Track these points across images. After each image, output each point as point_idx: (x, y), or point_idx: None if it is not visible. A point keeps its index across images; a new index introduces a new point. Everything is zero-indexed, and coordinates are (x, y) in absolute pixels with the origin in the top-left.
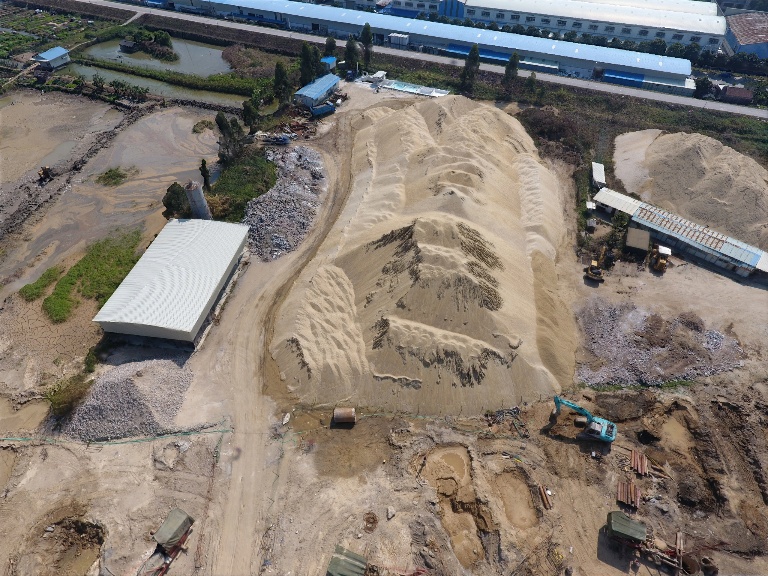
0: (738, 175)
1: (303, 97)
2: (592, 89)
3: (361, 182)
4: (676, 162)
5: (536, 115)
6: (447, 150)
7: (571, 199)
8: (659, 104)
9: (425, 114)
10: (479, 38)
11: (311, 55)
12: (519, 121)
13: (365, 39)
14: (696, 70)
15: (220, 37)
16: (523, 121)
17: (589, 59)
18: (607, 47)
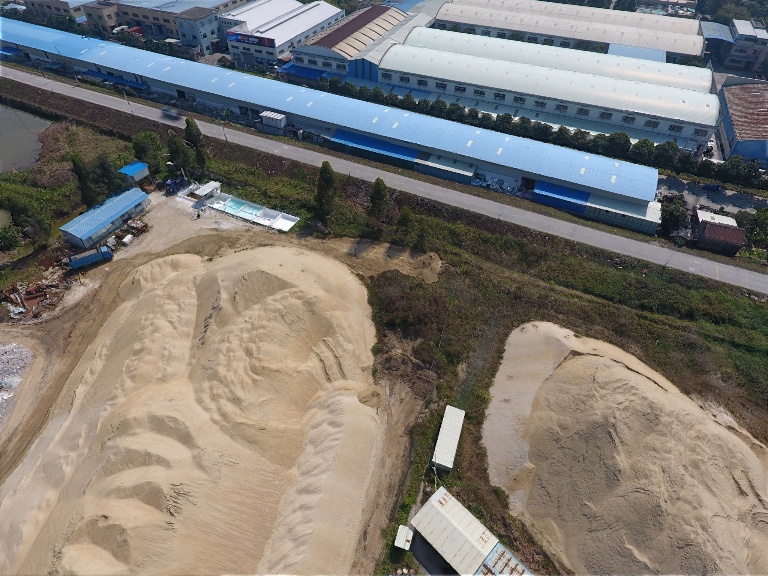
0: (678, 498)
1: (69, 235)
2: (505, 221)
3: (39, 446)
4: (573, 444)
5: (388, 291)
6: (155, 422)
7: (387, 498)
8: (598, 255)
9: (201, 297)
10: (374, 124)
11: (89, 171)
12: (367, 294)
13: (189, 138)
14: (672, 176)
15: (52, 108)
16: (372, 296)
17: (514, 166)
18: (547, 143)
